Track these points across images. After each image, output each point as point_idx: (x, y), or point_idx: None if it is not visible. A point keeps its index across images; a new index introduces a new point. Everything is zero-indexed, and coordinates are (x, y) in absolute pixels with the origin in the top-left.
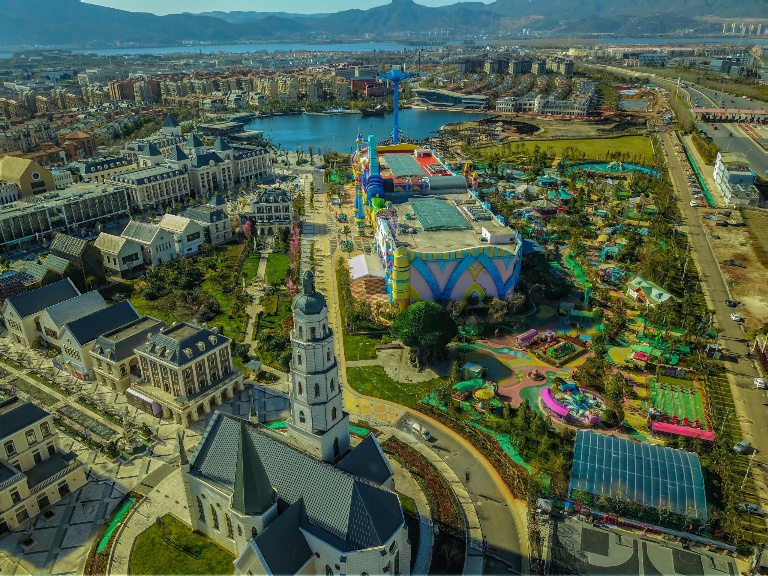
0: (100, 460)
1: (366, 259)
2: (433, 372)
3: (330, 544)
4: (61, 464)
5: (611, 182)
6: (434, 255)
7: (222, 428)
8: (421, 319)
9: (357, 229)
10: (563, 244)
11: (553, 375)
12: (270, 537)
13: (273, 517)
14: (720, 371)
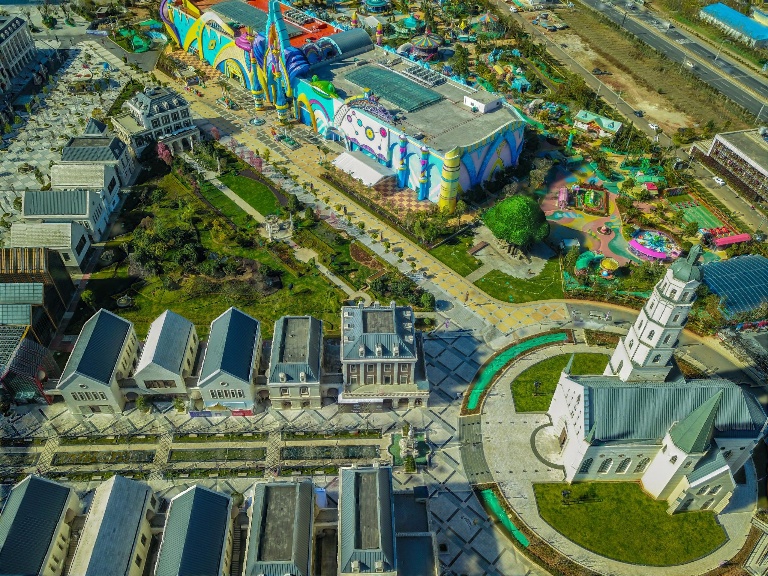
0: (403, 478)
1: (357, 158)
2: (538, 258)
3: (744, 437)
4: (409, 503)
5: None
6: (476, 145)
7: (597, 398)
8: (531, 217)
9: (280, 117)
10: (470, 83)
11: (612, 225)
12: None
13: None
14: (691, 179)
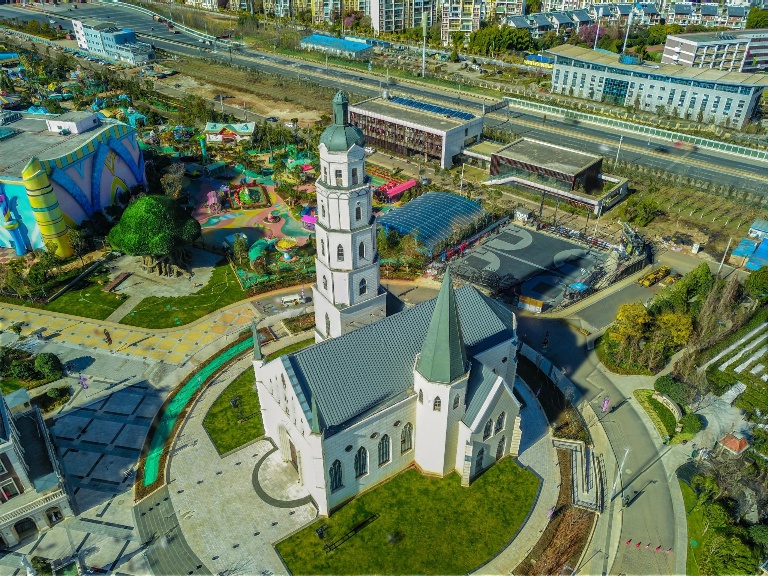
0: None
1: None
2: (202, 268)
3: (501, 343)
4: None
5: (10, 70)
6: (68, 157)
7: (306, 367)
8: (166, 214)
9: None
10: None
11: (279, 212)
12: None
13: None
14: None
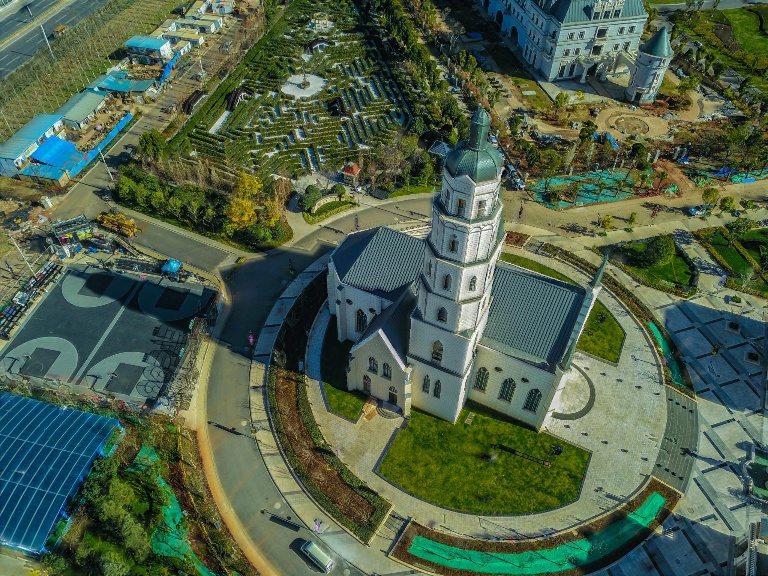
0: None
1: None
2: None
3: None
4: None
5: None
6: None
7: None
8: None
9: None
10: None
11: None
12: None
13: None
14: None
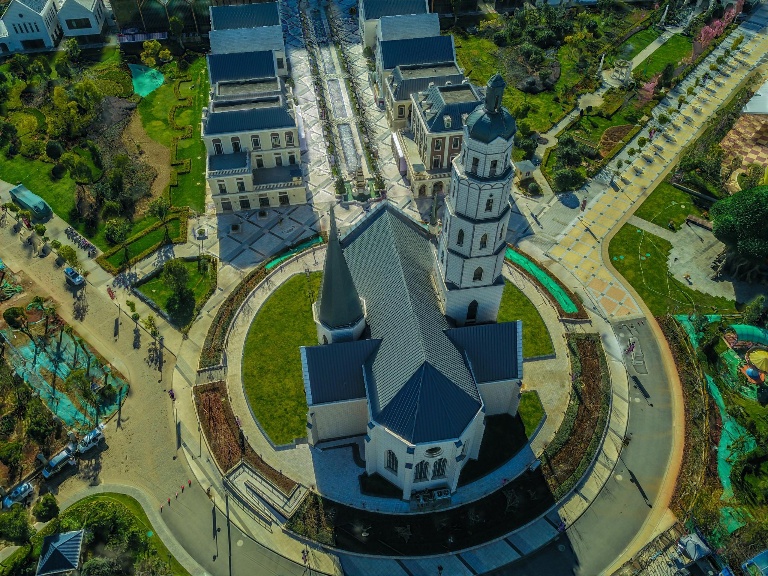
0: (330, 189)
1: None
2: (733, 289)
3: (370, 402)
4: None
5: None
6: None
7: (378, 221)
8: (760, 213)
9: None
10: None
11: None
12: (325, 355)
13: (348, 338)
14: None
